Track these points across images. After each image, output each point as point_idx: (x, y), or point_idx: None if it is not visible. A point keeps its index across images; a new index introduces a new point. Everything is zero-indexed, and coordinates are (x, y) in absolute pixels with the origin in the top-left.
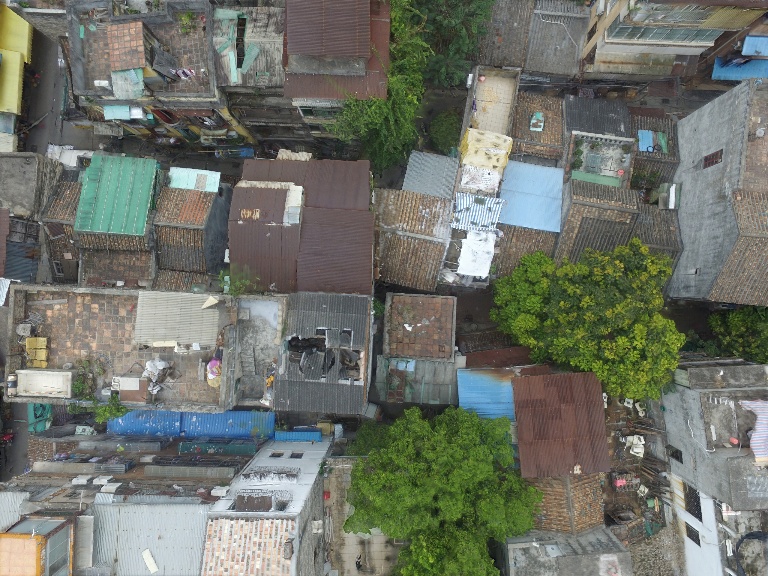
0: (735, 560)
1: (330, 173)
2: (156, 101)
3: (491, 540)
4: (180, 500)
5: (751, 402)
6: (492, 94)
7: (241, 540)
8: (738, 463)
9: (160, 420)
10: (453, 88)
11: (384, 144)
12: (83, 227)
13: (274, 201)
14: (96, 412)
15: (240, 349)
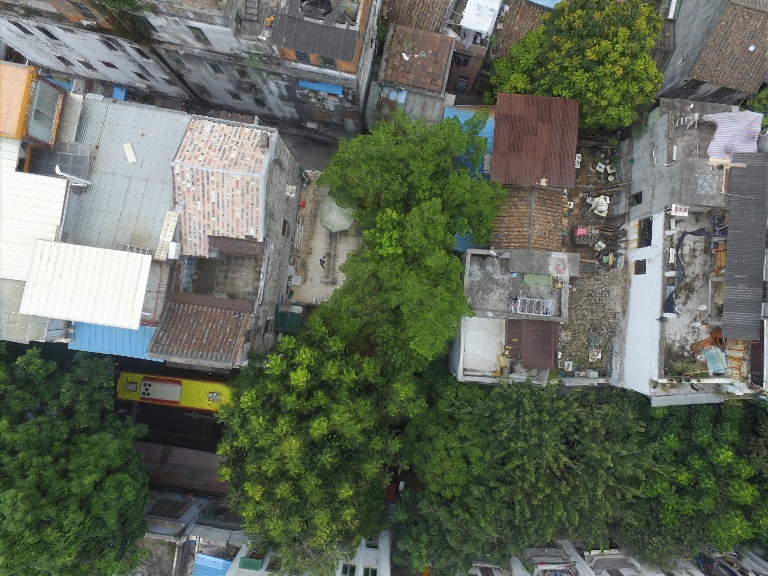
0: None
1: None
2: None
3: None
4: None
5: (714, 114)
6: None
7: (220, 137)
8: (693, 161)
9: None
10: None
11: None
12: None
13: None
14: None
15: None
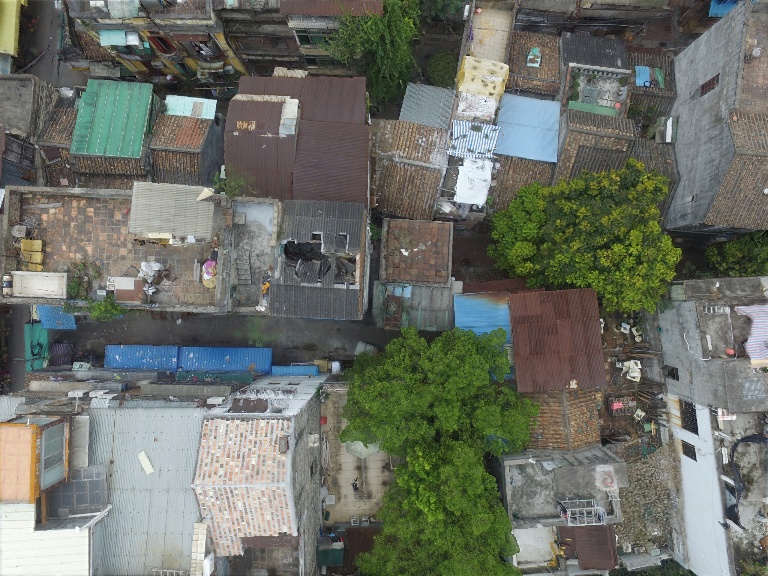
0: (731, 471)
1: (326, 89)
2: (152, 25)
3: (488, 464)
4: (176, 405)
5: (747, 307)
6: (489, 27)
7: (237, 438)
8: (734, 366)
9: (157, 356)
10: (450, 33)
11: (380, 68)
12: (79, 150)
13: (270, 113)
14: (91, 311)
15: (236, 255)
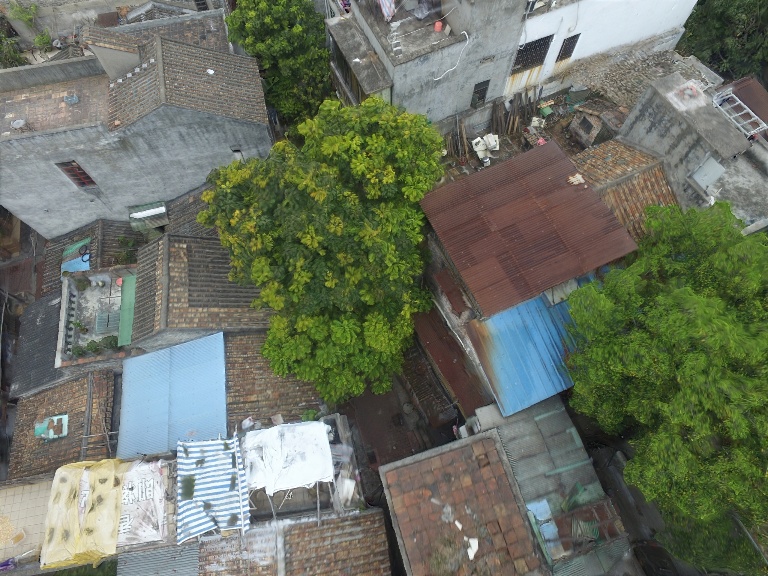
0: None
1: None
2: None
3: None
4: None
5: (383, 7)
6: None
7: None
8: None
9: None
10: None
11: None
12: None
13: None
14: None
15: None
